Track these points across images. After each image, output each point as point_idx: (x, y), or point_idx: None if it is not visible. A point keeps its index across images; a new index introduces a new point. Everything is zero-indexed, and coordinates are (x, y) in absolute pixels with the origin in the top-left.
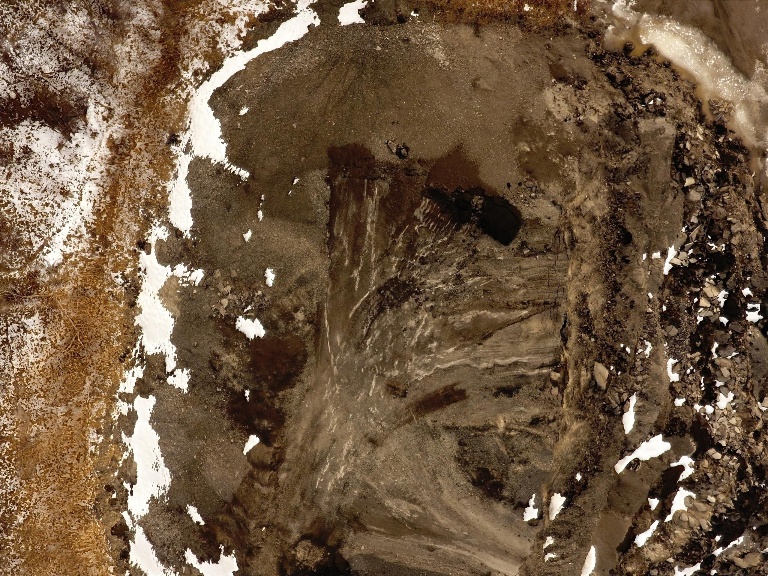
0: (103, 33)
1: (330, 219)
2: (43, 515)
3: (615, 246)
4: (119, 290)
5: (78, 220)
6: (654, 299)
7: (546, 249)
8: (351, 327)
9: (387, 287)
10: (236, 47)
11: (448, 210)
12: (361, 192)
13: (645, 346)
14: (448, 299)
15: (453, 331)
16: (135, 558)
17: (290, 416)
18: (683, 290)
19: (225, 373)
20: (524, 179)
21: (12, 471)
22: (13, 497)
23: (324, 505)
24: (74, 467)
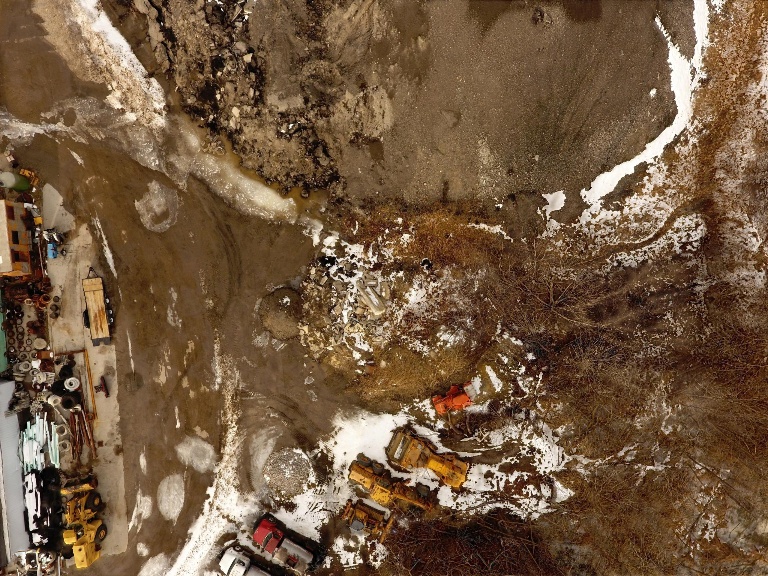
0: (764, 173)
1: None
2: None
3: None
4: None
5: None
6: None
7: None
8: None
9: None
10: (652, 167)
11: None
12: None
13: None
14: None
15: None
16: None
17: None
18: None
19: None
20: (427, 2)
21: None
22: None
23: None
24: None
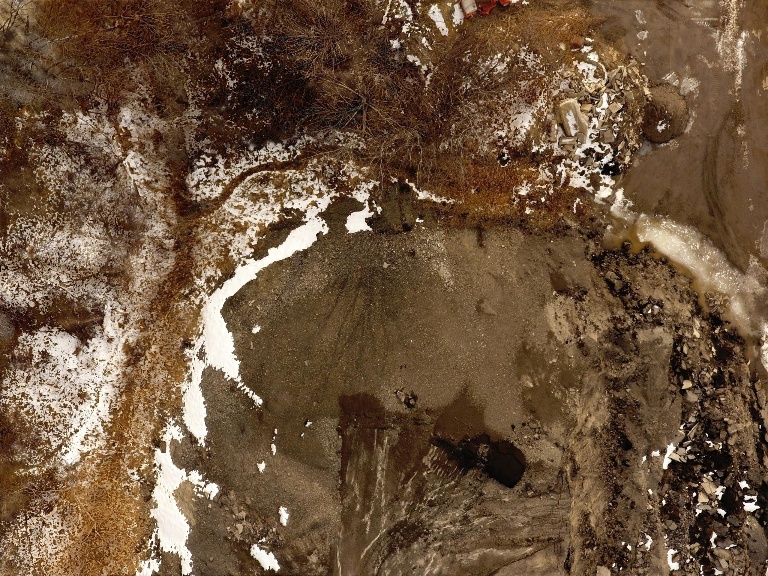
0: (119, 243)
1: (342, 467)
2: None
3: (616, 451)
4: (135, 484)
5: (95, 420)
6: (654, 496)
7: (549, 490)
8: (363, 567)
9: (397, 529)
10: (247, 255)
11: (455, 456)
12: (371, 441)
13: (646, 539)
14: (456, 538)
15: (461, 568)
16: None
17: None
18: (682, 486)
19: None
20: (528, 419)
21: None
22: None
23: None
24: None
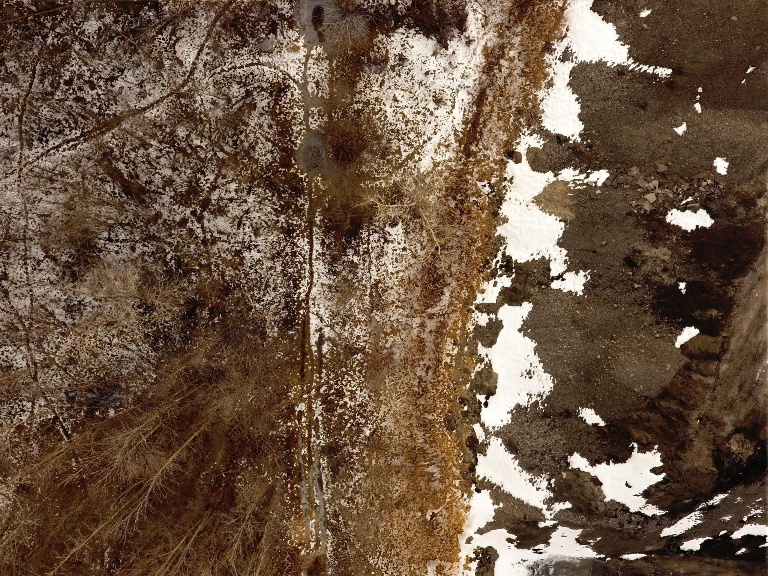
0: None
1: None
2: (390, 428)
3: None
4: (482, 200)
5: (449, 128)
6: None
7: None
8: None
9: None
10: None
11: None
12: None
13: None
14: None
15: None
16: (482, 472)
17: (739, 305)
18: None
19: (650, 268)
20: None
21: (362, 383)
22: (361, 409)
23: (762, 397)
24: (422, 380)
